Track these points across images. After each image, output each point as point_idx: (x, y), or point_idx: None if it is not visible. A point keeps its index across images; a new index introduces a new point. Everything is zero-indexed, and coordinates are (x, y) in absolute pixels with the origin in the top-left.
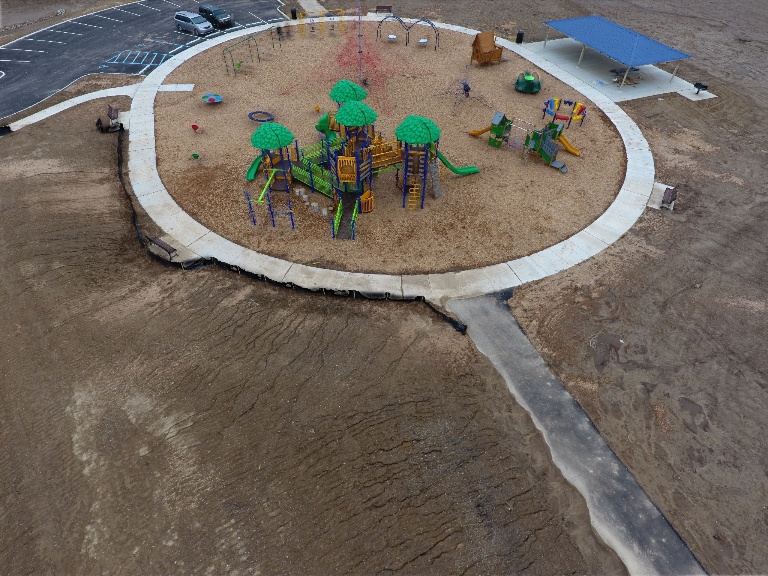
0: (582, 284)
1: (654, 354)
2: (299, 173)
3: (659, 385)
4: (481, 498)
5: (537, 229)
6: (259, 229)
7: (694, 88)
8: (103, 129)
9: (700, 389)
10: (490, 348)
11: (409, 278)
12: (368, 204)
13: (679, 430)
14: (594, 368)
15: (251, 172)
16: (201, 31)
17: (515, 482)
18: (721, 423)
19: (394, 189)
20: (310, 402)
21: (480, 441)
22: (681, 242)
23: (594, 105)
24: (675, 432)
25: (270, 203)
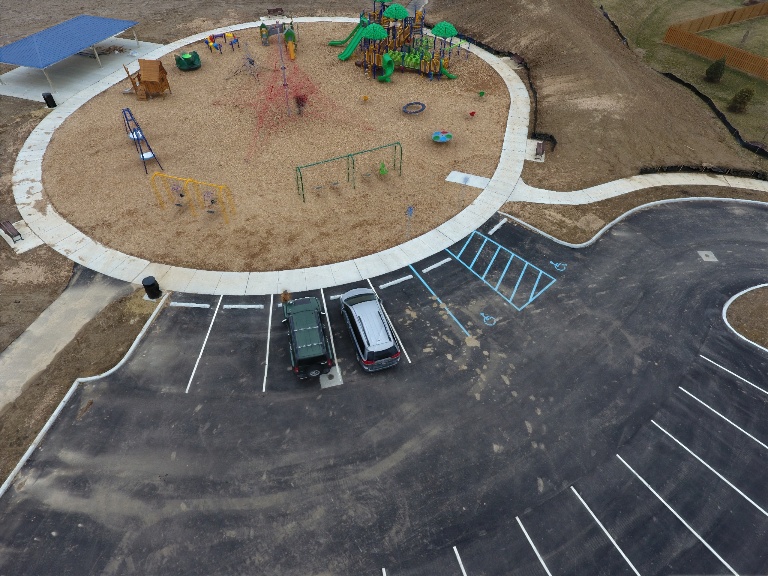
0: None
1: None
2: None
3: None
4: None
5: None
6: None
7: None
8: (551, 145)
9: None
10: None
11: None
12: None
13: None
14: None
15: None
16: None
17: None
18: None
19: None
20: (484, 4)
21: (442, 5)
22: (306, 8)
23: (182, 48)
24: None
25: None
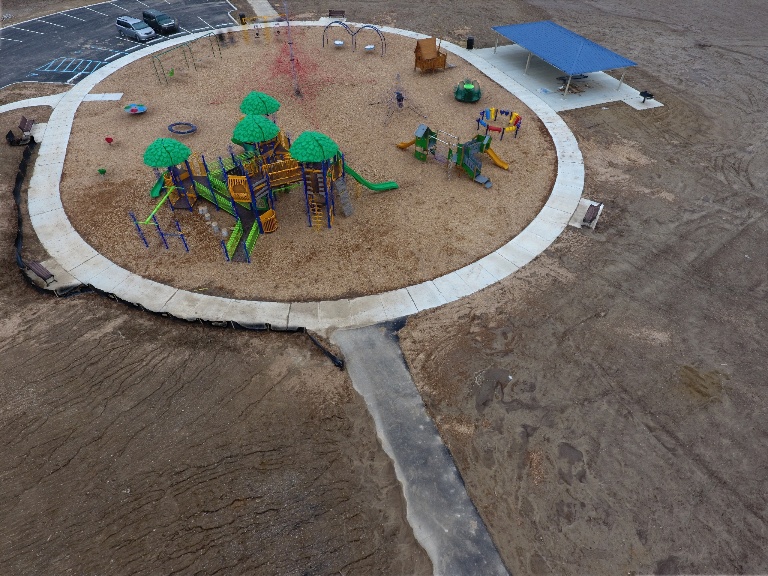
0: (481, 312)
1: (542, 392)
2: (203, 190)
3: (541, 428)
4: (311, 566)
5: (447, 250)
6: (151, 251)
7: (641, 96)
8: (14, 142)
9: (584, 433)
10: (367, 386)
11: (298, 306)
12: (269, 224)
13: (552, 481)
14: (474, 408)
15: (157, 188)
16: (142, 37)
17: (357, 545)
18: (599, 473)
19: (305, 206)
20: (136, 456)
21: (328, 496)
22: (595, 265)
23: (534, 115)
24: (547, 483)
25: (168, 223)
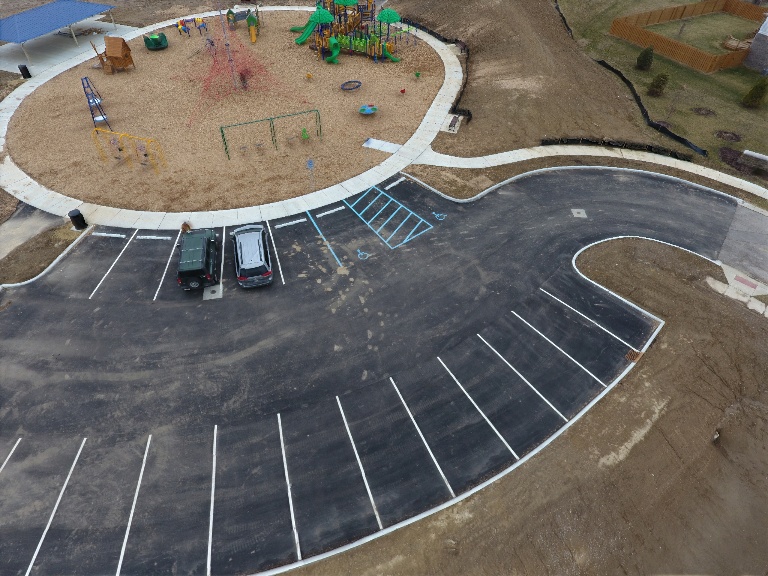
0: None
1: None
2: None
3: None
4: None
5: None
6: None
7: None
8: None
9: None
10: None
11: None
12: None
13: None
14: None
15: None
16: None
17: None
18: None
19: None
20: None
21: None
22: None
23: (155, 31)
24: None
25: None
